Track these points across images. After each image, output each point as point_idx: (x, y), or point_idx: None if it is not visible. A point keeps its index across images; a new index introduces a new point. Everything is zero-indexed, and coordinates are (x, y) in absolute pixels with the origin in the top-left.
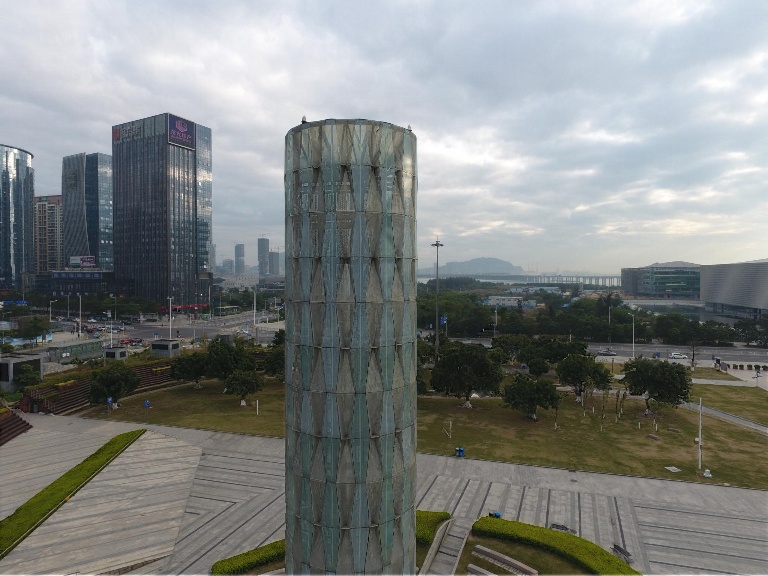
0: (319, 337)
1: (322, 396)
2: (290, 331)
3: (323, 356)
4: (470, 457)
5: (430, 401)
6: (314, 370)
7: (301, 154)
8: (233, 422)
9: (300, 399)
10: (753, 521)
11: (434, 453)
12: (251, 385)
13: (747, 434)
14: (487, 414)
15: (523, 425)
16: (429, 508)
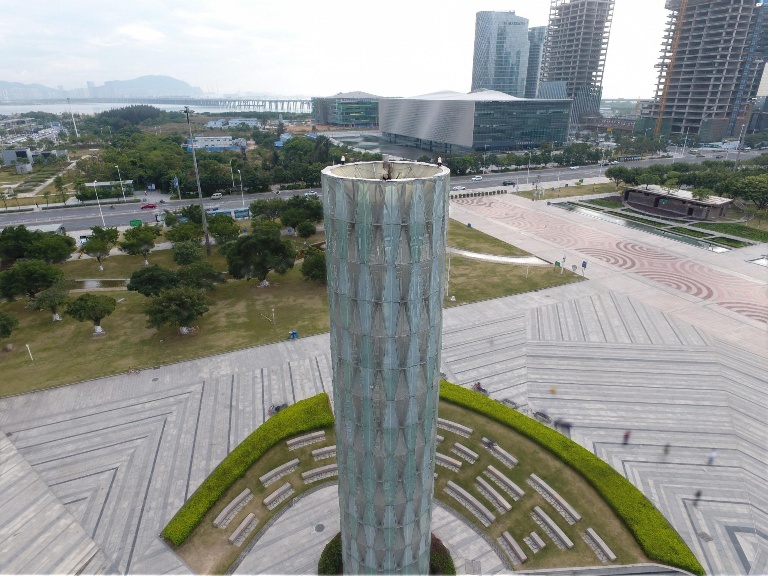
0: (401, 360)
1: (406, 401)
2: (363, 358)
3: (407, 374)
4: (302, 336)
5: (225, 287)
6: (398, 385)
7: (384, 210)
8: (6, 380)
9: (382, 407)
10: (486, 325)
11: (271, 342)
12: (2, 328)
13: (458, 260)
14: (287, 288)
15: (322, 292)
16: (304, 394)
